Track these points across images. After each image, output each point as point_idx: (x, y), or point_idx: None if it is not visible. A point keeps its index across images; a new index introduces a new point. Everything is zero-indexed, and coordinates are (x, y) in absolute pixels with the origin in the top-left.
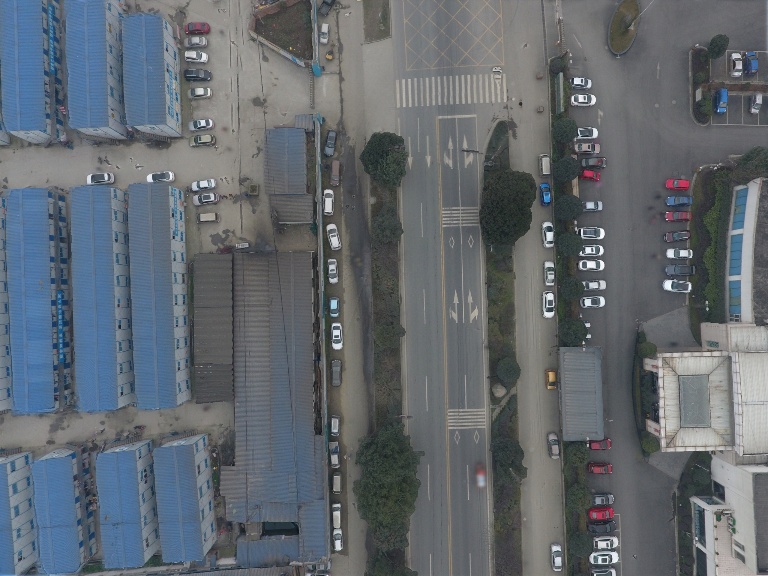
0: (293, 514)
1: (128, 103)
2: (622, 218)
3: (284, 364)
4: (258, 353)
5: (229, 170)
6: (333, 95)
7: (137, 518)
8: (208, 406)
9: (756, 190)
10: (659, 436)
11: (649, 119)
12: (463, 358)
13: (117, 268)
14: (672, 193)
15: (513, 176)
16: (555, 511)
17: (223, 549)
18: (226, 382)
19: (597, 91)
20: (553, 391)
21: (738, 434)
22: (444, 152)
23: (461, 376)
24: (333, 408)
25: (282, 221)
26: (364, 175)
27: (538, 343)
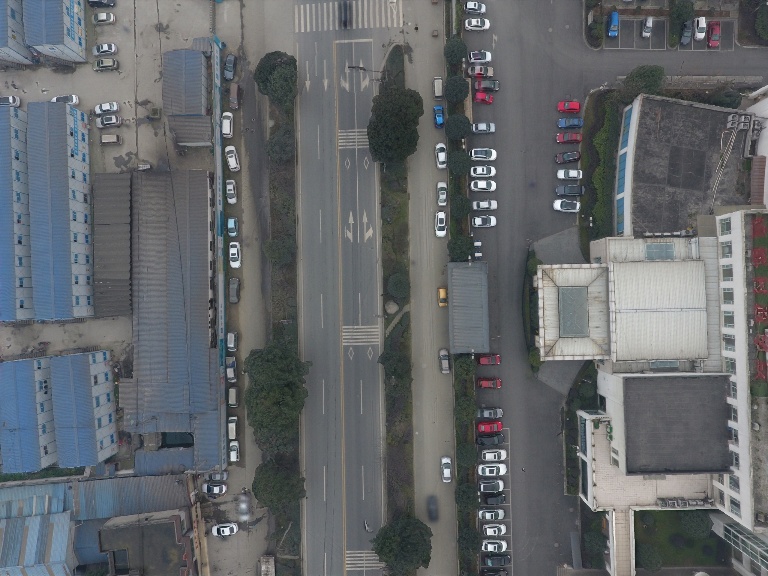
0: (187, 423)
1: (27, 23)
2: (515, 140)
3: (179, 279)
4: (155, 269)
5: (132, 94)
6: (234, 21)
7: (34, 424)
8: (111, 323)
9: (637, 106)
10: None
11: (543, 43)
12: (358, 276)
13: (17, 185)
14: (564, 116)
15: (397, 91)
16: (446, 425)
17: (124, 461)
18: (124, 297)
19: (492, 16)
20: (445, 309)
21: (612, 341)
22: (341, 76)
23: (355, 294)
24: (231, 325)
25: (180, 142)
26: (263, 99)
27: (431, 262)
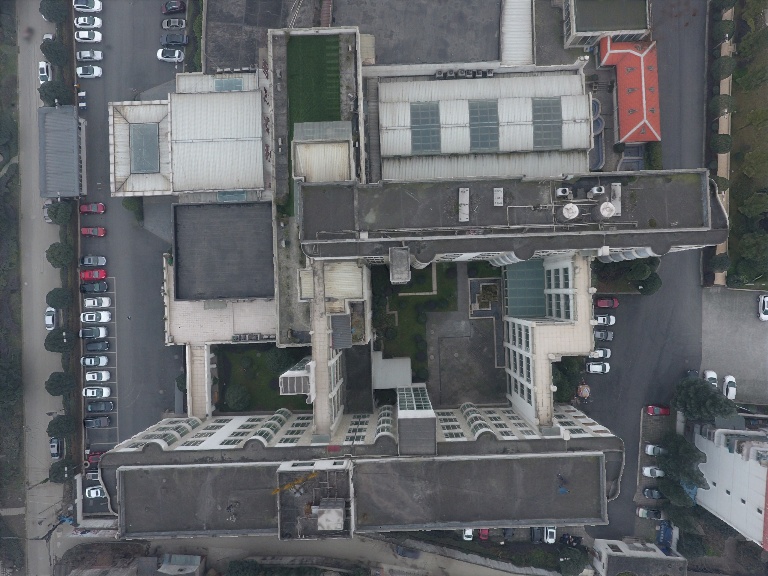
0: None
1: None
2: None
3: None
4: None
5: None
6: None
7: None
8: None
9: None
10: None
11: None
12: None
13: None
14: None
15: None
16: (55, 275)
17: None
18: None
19: None
20: None
21: None
22: None
23: None
24: None
25: None
26: None
27: None
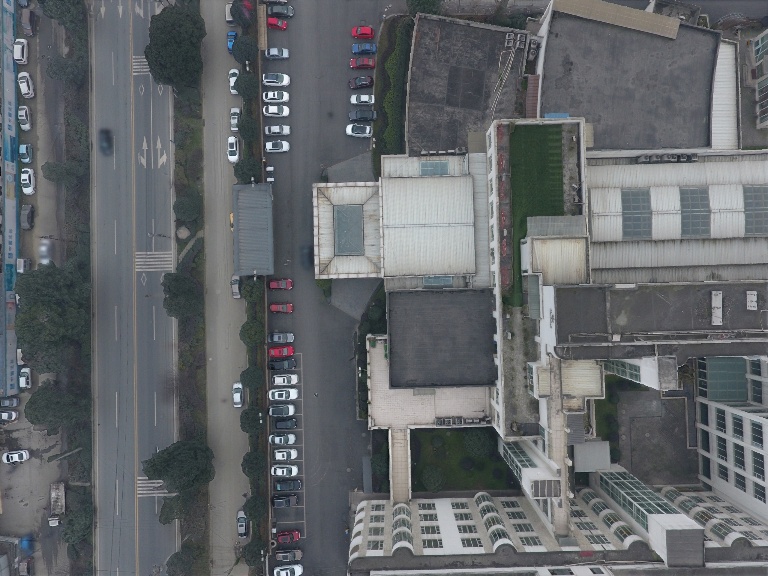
0: None
1: None
2: (310, 66)
3: None
4: None
5: None
6: None
7: None
8: None
9: None
10: (314, 264)
11: None
12: (151, 202)
13: None
14: None
15: (170, 10)
16: (240, 351)
17: None
18: None
19: None
20: None
21: None
22: (135, 2)
23: (149, 220)
24: (25, 252)
25: None
26: (59, 26)
27: (226, 188)
